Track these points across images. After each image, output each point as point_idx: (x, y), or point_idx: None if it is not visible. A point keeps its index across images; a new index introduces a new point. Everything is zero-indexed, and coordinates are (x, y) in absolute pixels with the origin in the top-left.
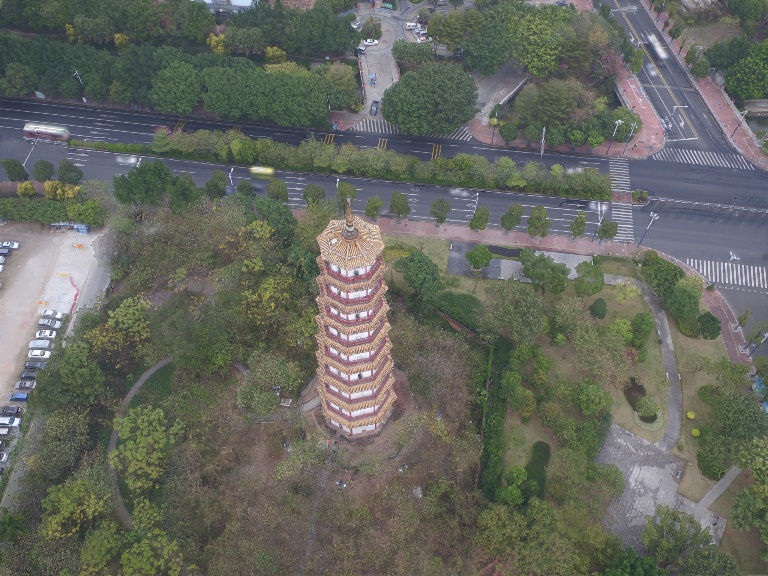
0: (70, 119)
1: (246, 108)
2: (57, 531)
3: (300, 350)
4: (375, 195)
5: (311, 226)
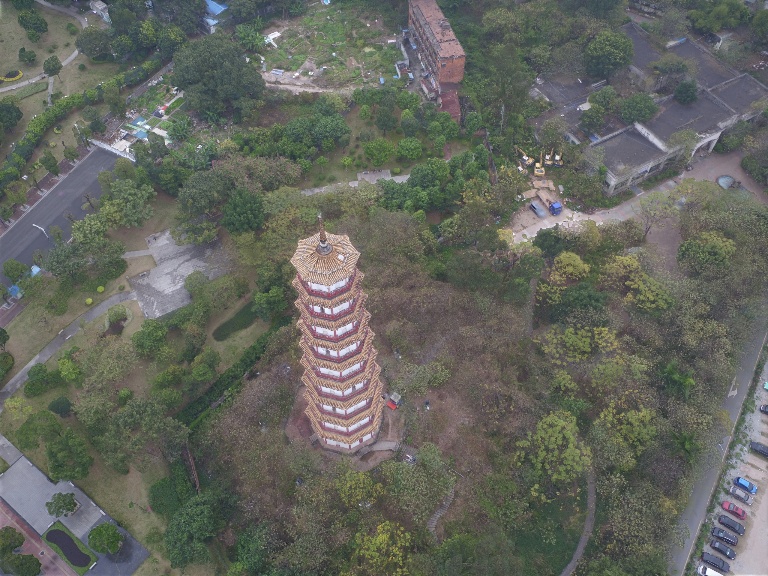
0: None
1: None
2: None
3: None
4: None
5: None
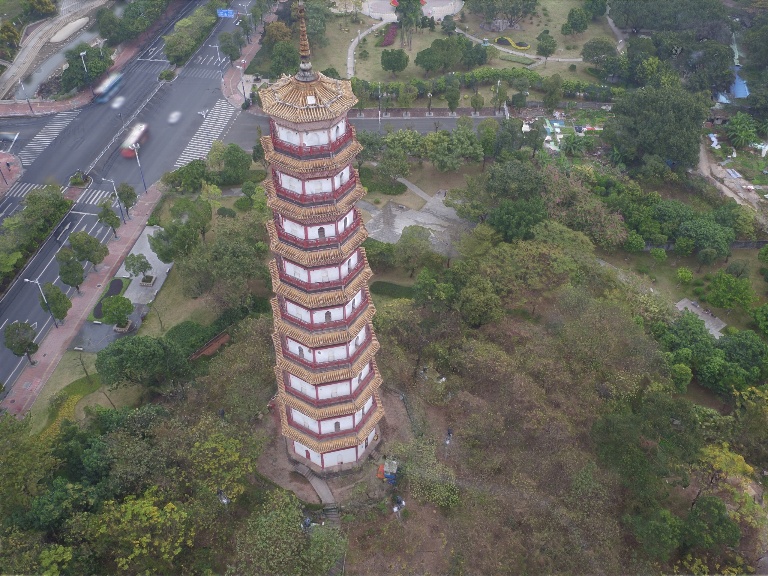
0: None
1: None
2: None
3: (232, 507)
4: None
5: (5, 467)
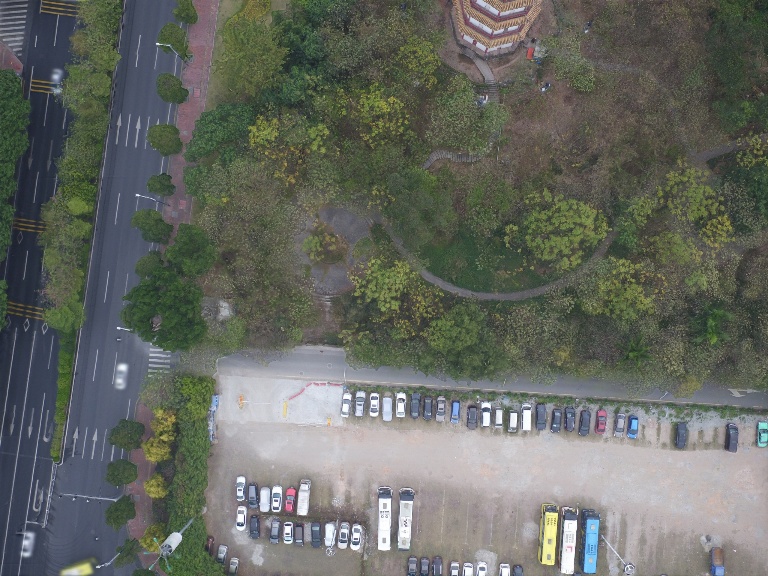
0: (2, 473)
1: (3, 194)
2: (651, 298)
3: None
4: (174, 1)
5: None
